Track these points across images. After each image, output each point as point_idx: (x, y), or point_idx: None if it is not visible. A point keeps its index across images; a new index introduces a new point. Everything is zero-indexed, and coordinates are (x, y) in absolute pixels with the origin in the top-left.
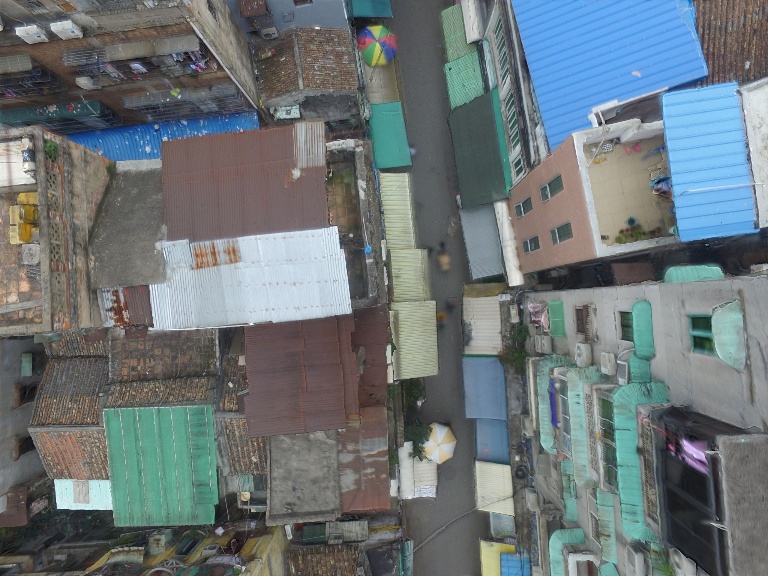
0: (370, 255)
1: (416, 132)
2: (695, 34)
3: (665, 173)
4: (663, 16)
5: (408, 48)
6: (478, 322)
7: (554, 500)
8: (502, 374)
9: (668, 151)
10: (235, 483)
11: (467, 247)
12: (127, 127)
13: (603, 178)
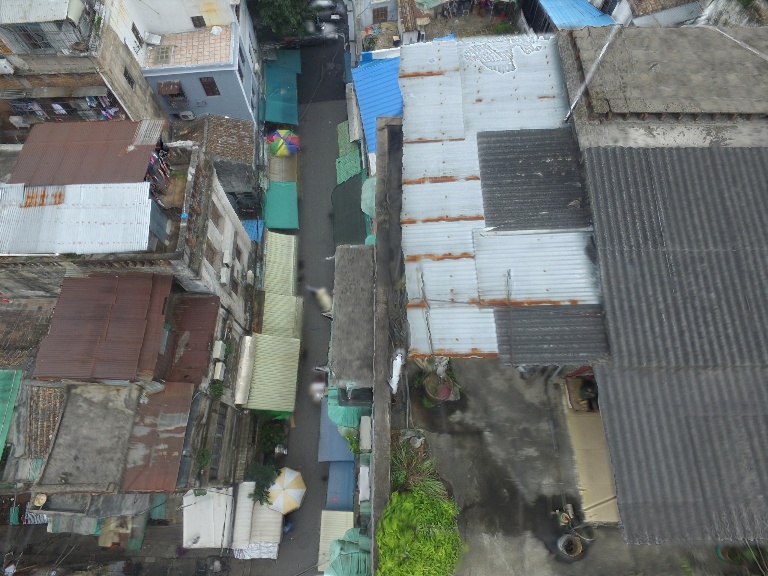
0: (185, 220)
1: (313, 212)
2: None
3: None
4: None
5: (315, 153)
6: None
7: None
8: None
9: None
10: (26, 469)
11: None
12: None
13: None
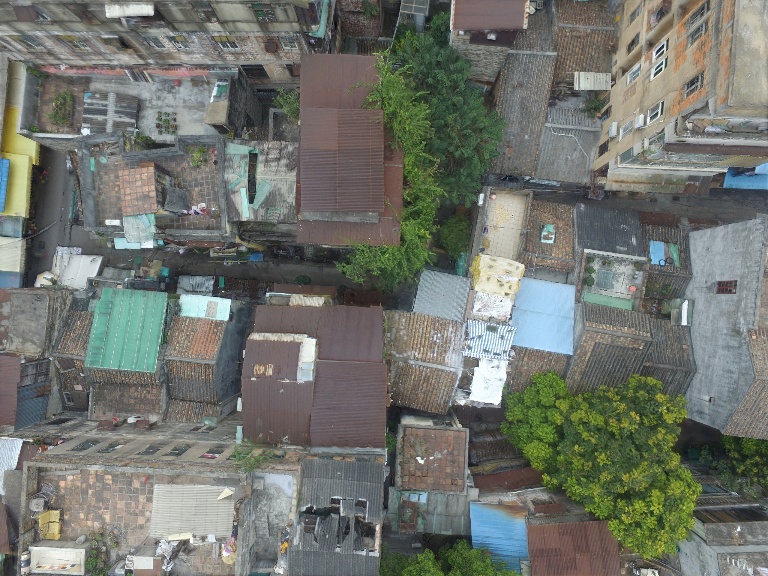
0: None
1: None
2: None
3: None
4: None
5: None
6: None
7: None
8: None
9: None
10: None
11: None
12: None
13: None
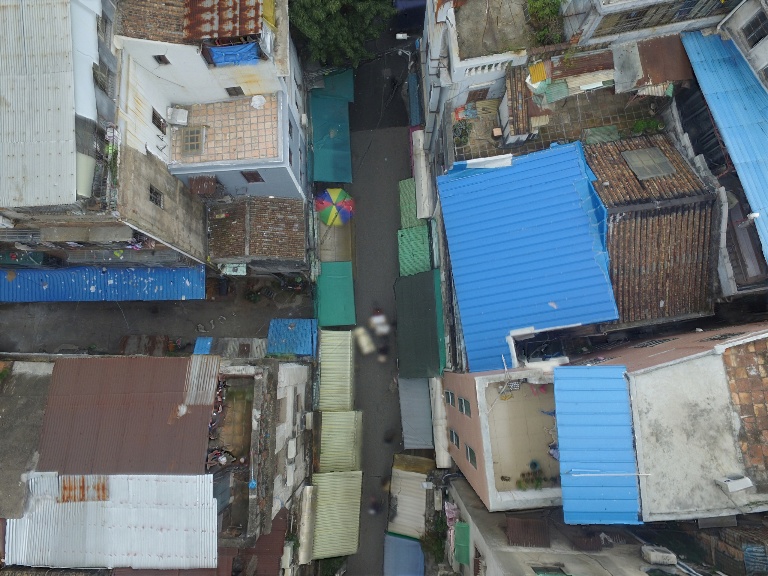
0: (254, 491)
1: (368, 284)
2: (608, 277)
3: (555, 443)
4: (579, 255)
5: (369, 204)
6: (404, 498)
7: None
8: (422, 562)
9: (557, 425)
10: None
11: (402, 414)
12: (74, 268)
13: (509, 415)
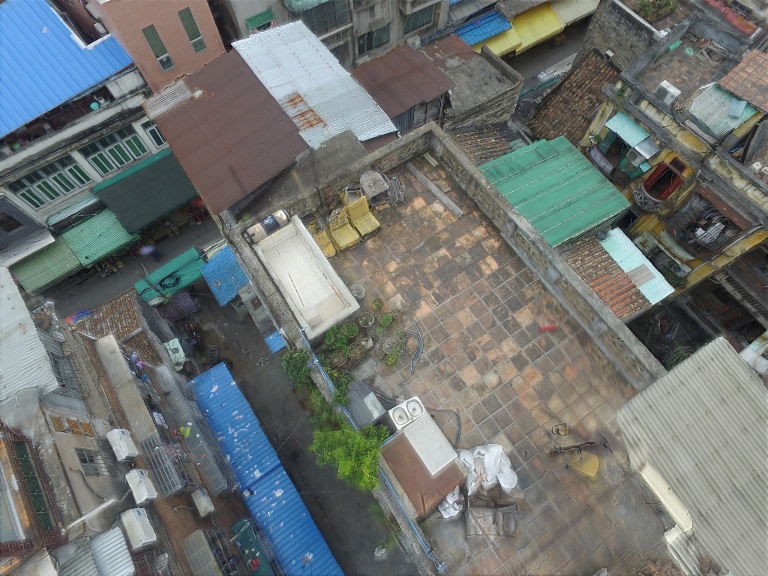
0: None
1: None
2: (2, 4)
3: None
4: None
5: None
6: None
7: (396, 7)
8: None
9: None
10: None
11: None
12: None
13: None
